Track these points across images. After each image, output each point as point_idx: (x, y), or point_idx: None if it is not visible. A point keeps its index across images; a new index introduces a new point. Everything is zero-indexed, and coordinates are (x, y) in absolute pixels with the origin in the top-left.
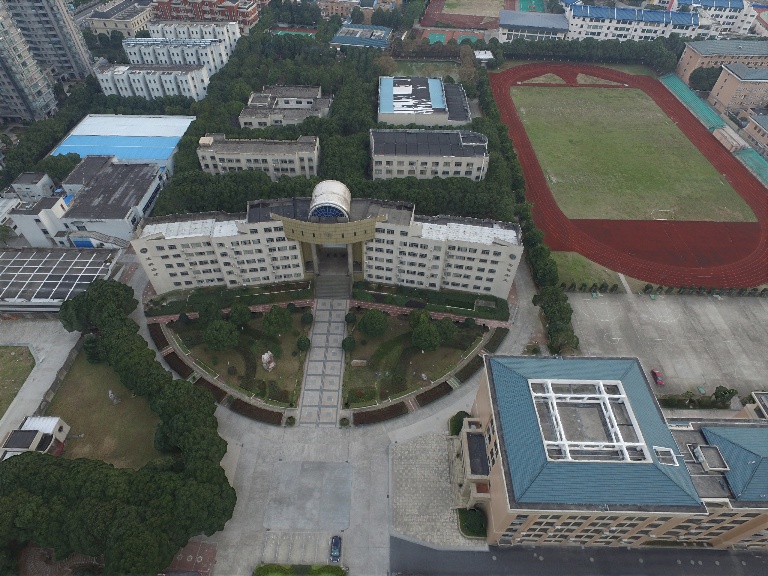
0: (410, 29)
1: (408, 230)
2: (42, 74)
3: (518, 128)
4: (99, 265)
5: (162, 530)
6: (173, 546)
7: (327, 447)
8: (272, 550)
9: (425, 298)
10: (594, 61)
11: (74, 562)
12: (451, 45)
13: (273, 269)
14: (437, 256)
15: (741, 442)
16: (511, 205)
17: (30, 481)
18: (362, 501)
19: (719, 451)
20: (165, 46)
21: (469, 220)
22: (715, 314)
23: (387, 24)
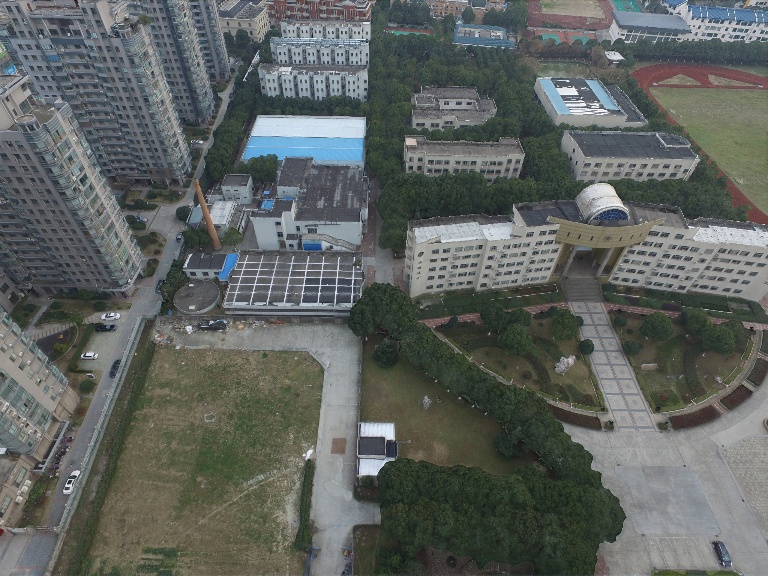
0: (525, 29)
1: (686, 233)
2: (207, 74)
3: None
4: (350, 268)
5: (581, 537)
6: (595, 553)
7: (658, 451)
8: (658, 556)
9: (678, 301)
10: (718, 62)
11: (479, 570)
12: (578, 46)
13: (525, 272)
14: (703, 259)
15: None
16: None
17: (428, 489)
18: (721, 505)
19: None
20: (315, 46)
21: (728, 223)
22: None
23: (500, 24)
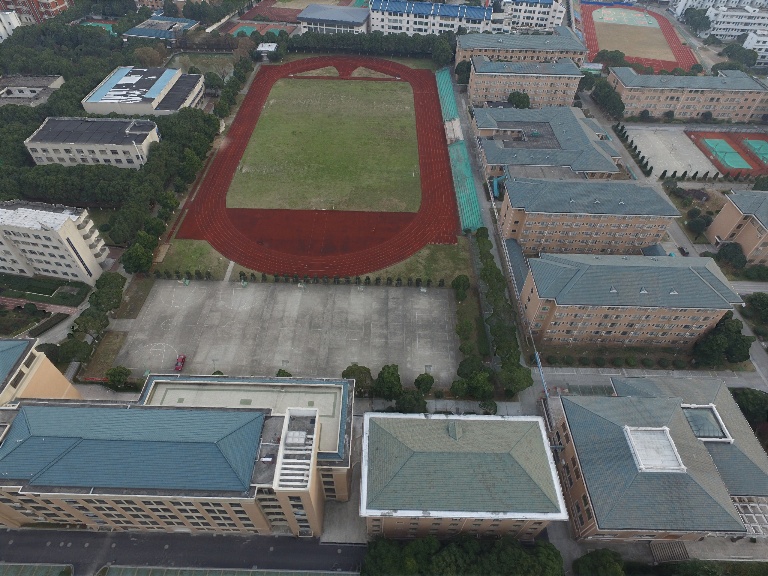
0: (217, 22)
1: None
2: None
3: (251, 119)
4: None
5: None
6: None
7: None
8: None
9: (8, 284)
10: (385, 55)
11: None
12: (238, 37)
13: None
14: None
15: (36, 421)
16: (147, 193)
17: None
18: None
19: (5, 430)
20: None
21: (43, 205)
22: (295, 302)
23: (197, 17)
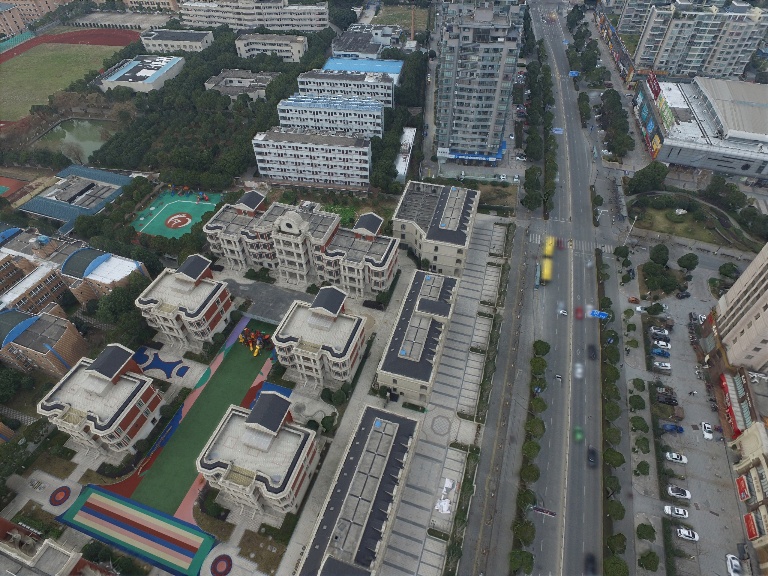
0: None
1: None
2: None
3: None
4: None
5: None
6: None
7: None
8: None
9: None
10: None
11: None
12: (5, 148)
13: None
14: None
15: None
16: None
17: None
18: None
19: None
20: None
21: (196, 7)
22: None
23: None
